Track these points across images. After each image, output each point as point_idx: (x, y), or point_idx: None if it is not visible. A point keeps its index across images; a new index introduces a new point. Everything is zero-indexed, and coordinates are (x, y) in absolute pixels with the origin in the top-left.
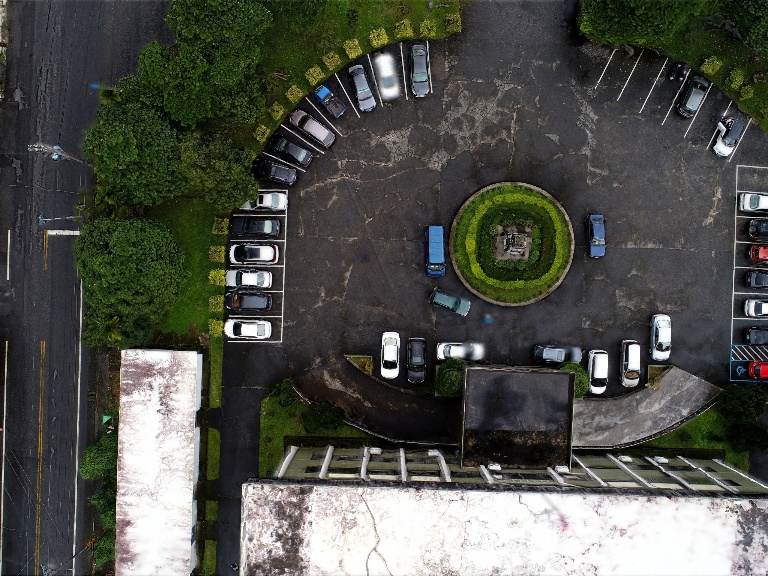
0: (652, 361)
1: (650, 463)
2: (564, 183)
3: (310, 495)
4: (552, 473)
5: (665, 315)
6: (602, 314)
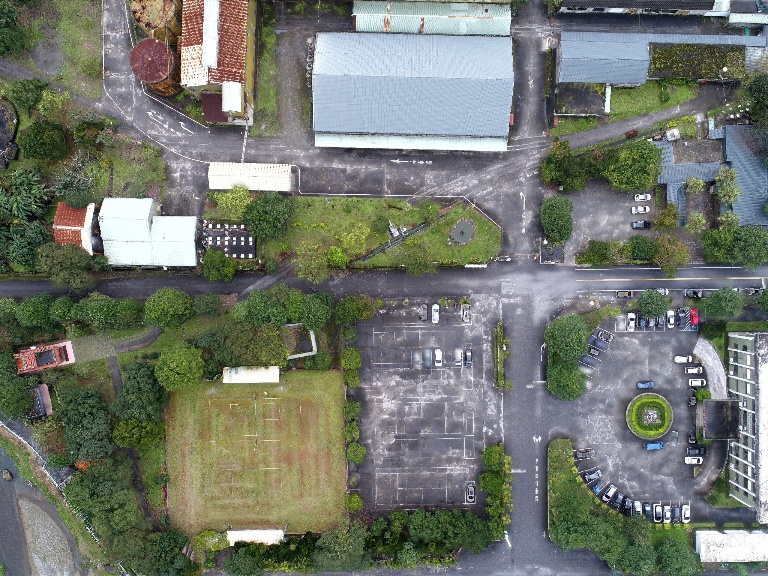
0: (692, 361)
1: (733, 365)
2: (625, 397)
3: (761, 501)
4: (743, 410)
5: (675, 358)
6: (674, 380)
